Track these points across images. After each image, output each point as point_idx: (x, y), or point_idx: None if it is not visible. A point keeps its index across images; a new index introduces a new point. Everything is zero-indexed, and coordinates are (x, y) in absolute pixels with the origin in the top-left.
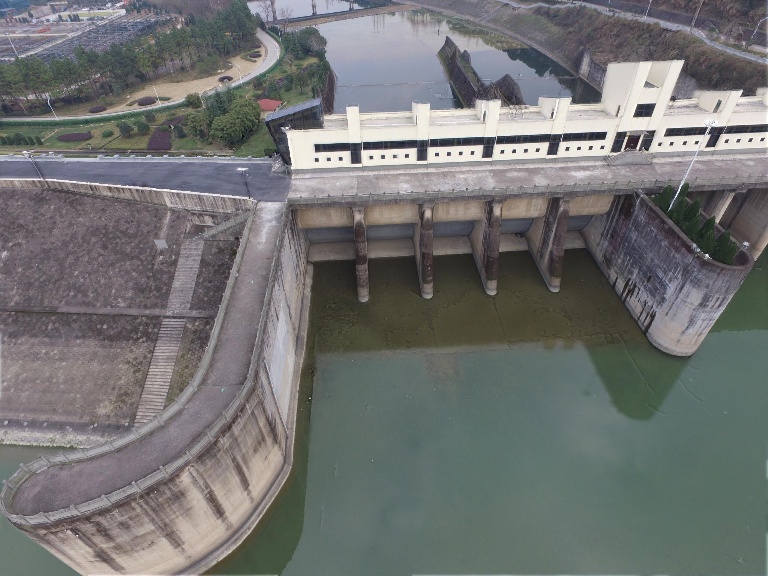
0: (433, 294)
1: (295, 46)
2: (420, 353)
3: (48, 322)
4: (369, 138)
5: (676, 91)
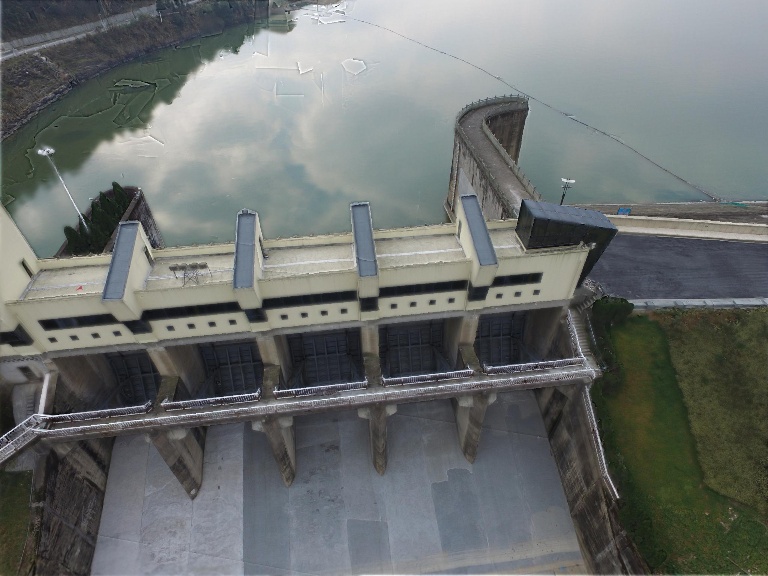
0: None
1: None
2: None
3: (671, 215)
4: None
5: None
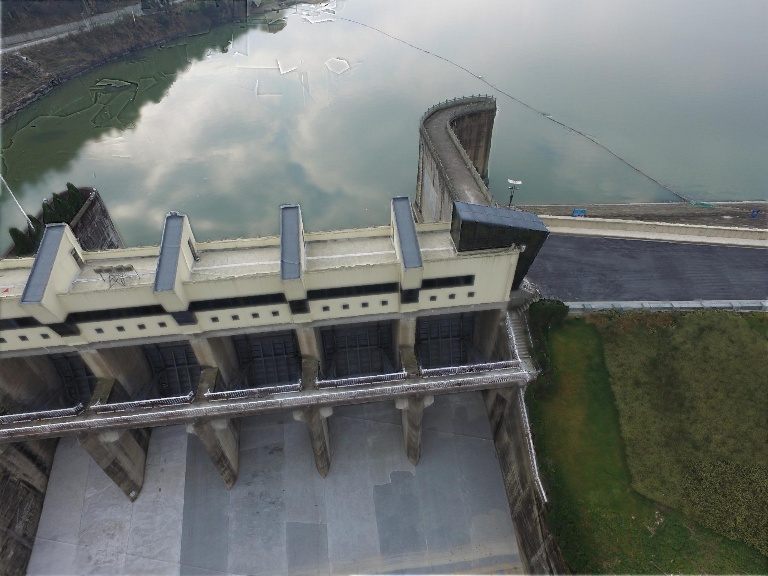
0: None
1: None
2: None
3: None
4: None
5: None
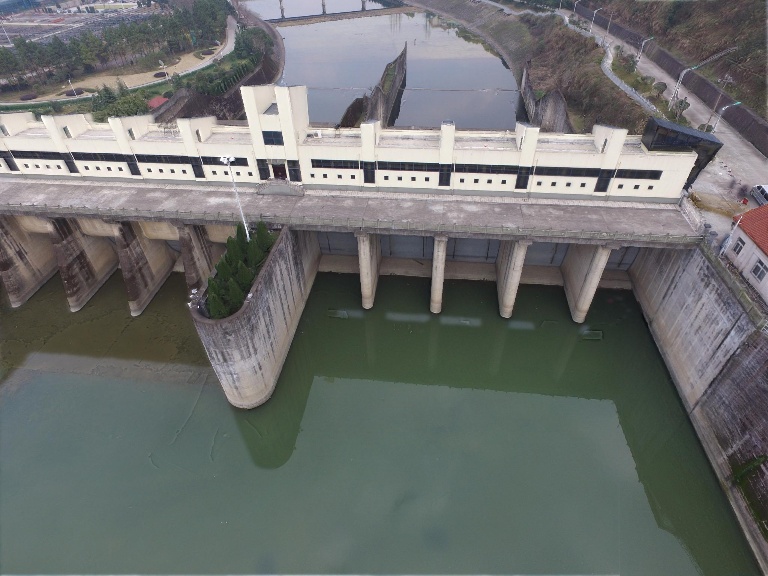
0: (82, 308)
1: (239, 45)
2: (7, 366)
3: None
4: (15, 147)
5: (555, 114)
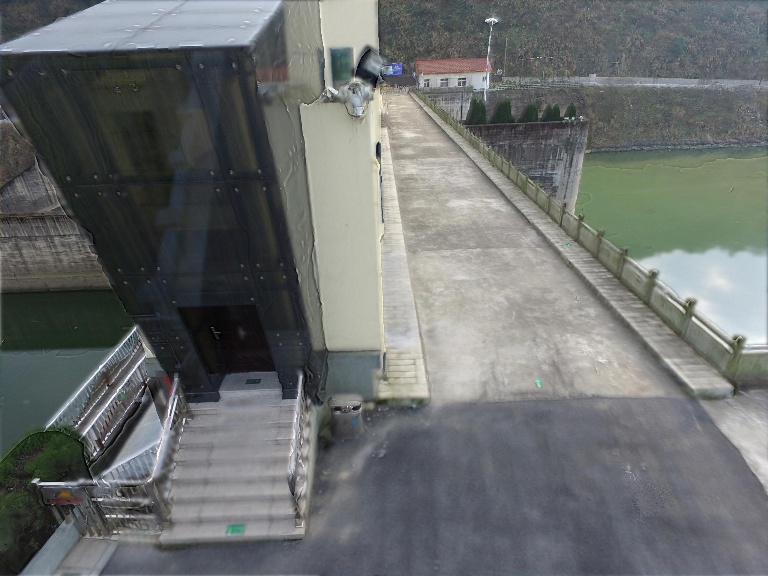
0: None
1: None
2: None
3: None
4: None
5: None
